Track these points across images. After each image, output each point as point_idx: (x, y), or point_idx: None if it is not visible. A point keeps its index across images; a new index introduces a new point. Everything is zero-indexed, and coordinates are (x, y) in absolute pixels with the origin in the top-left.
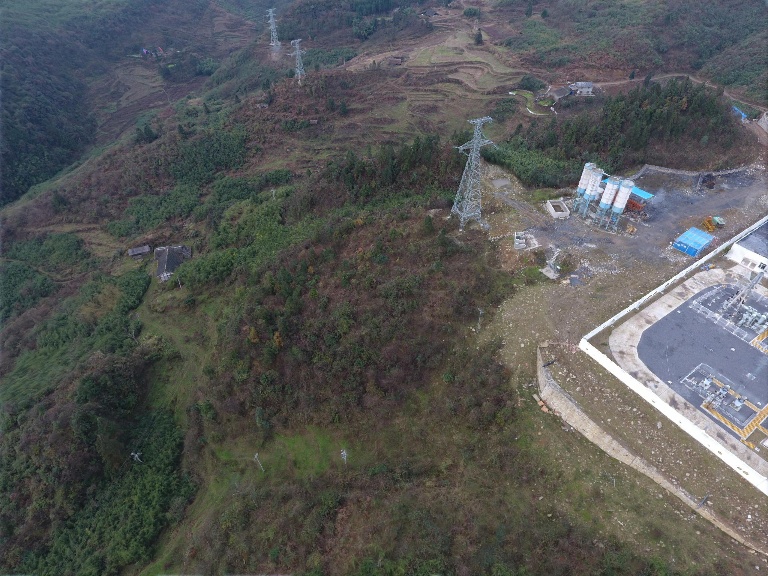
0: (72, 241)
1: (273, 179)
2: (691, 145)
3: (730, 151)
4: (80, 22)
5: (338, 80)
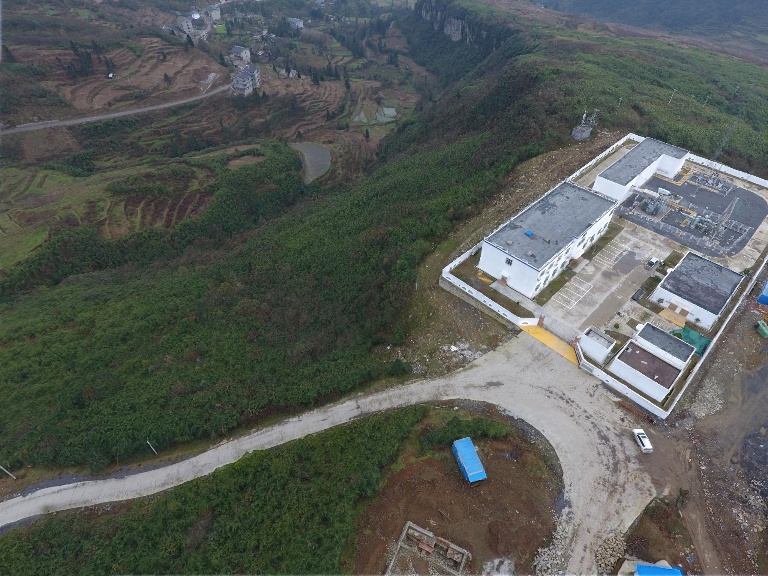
0: None
1: None
2: None
3: None
4: None
5: None
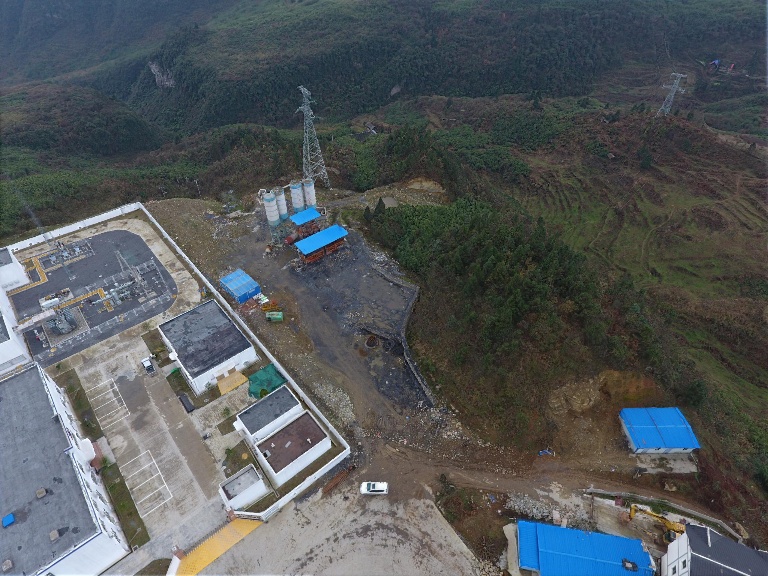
0: (420, 124)
1: (514, 167)
2: (444, 311)
3: (463, 375)
4: (693, 18)
5: (684, 136)
